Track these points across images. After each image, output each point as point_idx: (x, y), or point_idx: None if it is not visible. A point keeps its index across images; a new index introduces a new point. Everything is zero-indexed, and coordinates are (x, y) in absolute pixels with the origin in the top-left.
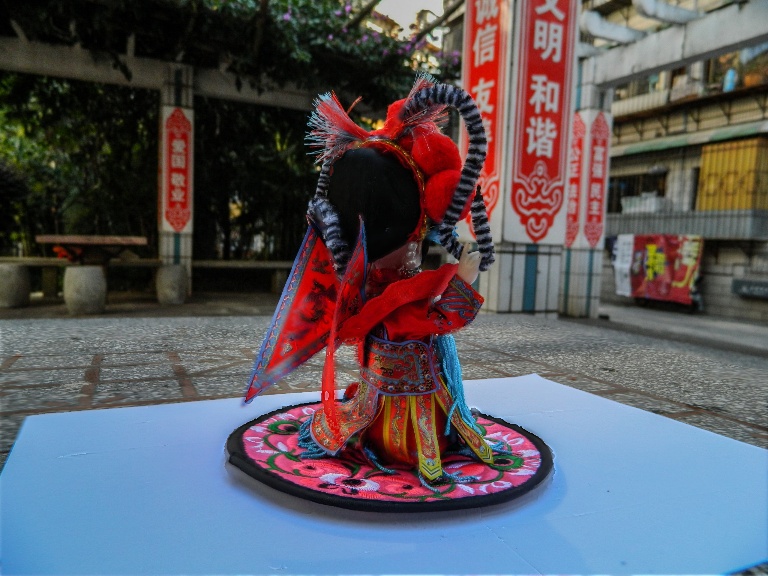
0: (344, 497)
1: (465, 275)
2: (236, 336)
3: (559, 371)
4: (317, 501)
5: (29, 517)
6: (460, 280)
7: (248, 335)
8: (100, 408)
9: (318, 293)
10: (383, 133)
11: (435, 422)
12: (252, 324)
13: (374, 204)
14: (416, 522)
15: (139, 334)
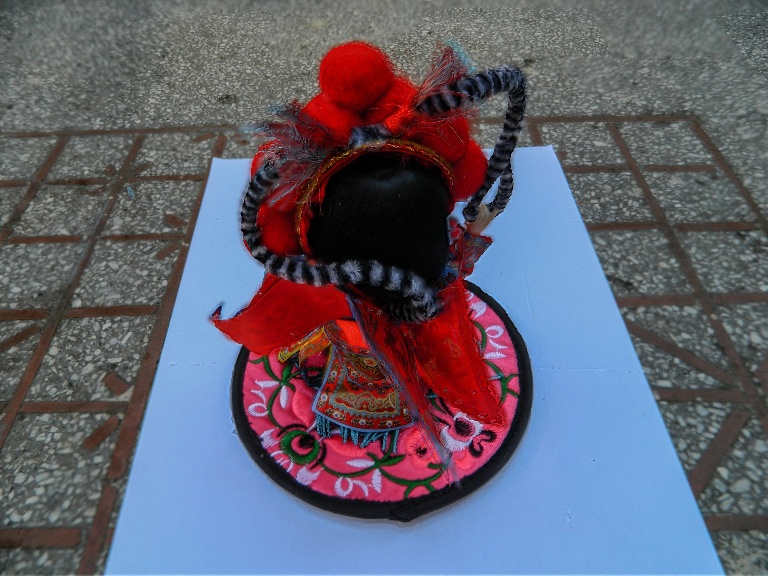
0: (503, 445)
1: (478, 231)
2: None
3: (207, 133)
4: (503, 466)
5: None
6: (476, 238)
7: None
8: None
9: (392, 352)
10: (348, 121)
11: None
12: None
13: None
14: None
15: None
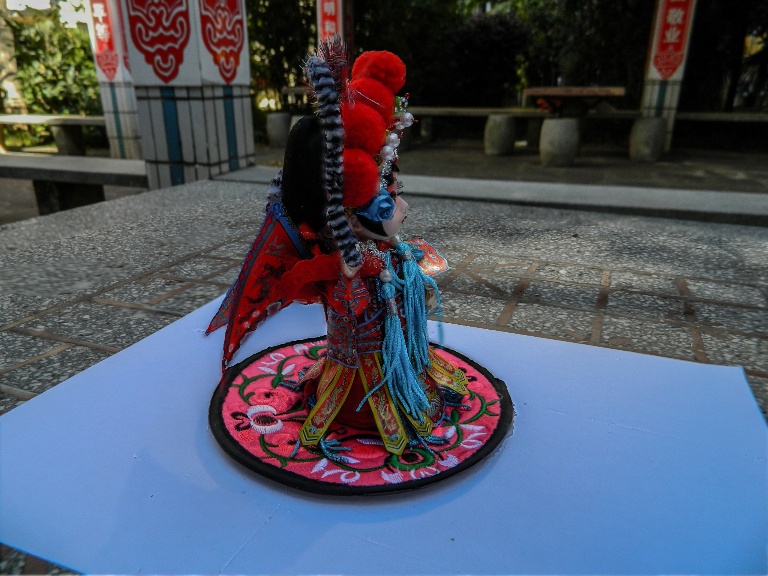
0: (225, 429)
1: None
2: (498, 236)
3: None
4: (210, 424)
5: (119, 366)
6: (342, 271)
7: (511, 236)
8: None
9: None
10: None
11: (347, 396)
12: (543, 221)
13: (288, 182)
14: (242, 472)
15: (422, 222)
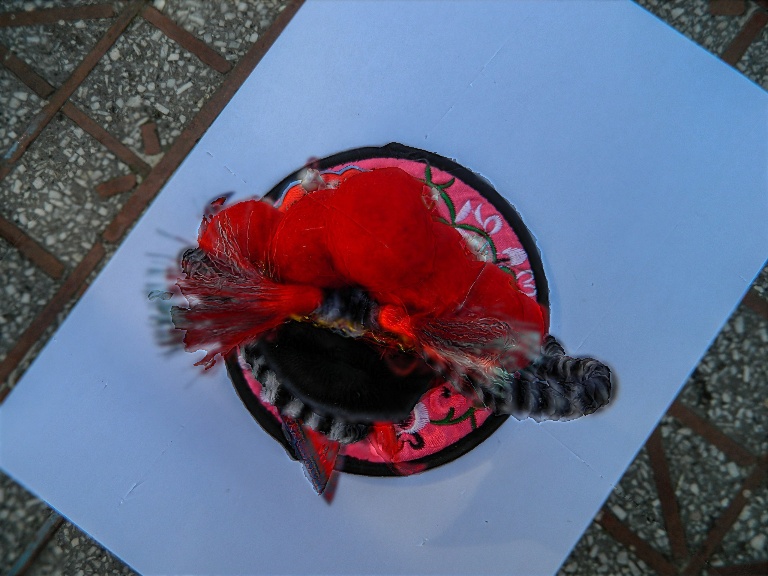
0: (421, 460)
1: None
2: None
3: None
4: None
5: None
6: None
7: None
8: (12, 377)
9: None
10: (332, 282)
11: None
12: None
13: None
14: None
15: None
